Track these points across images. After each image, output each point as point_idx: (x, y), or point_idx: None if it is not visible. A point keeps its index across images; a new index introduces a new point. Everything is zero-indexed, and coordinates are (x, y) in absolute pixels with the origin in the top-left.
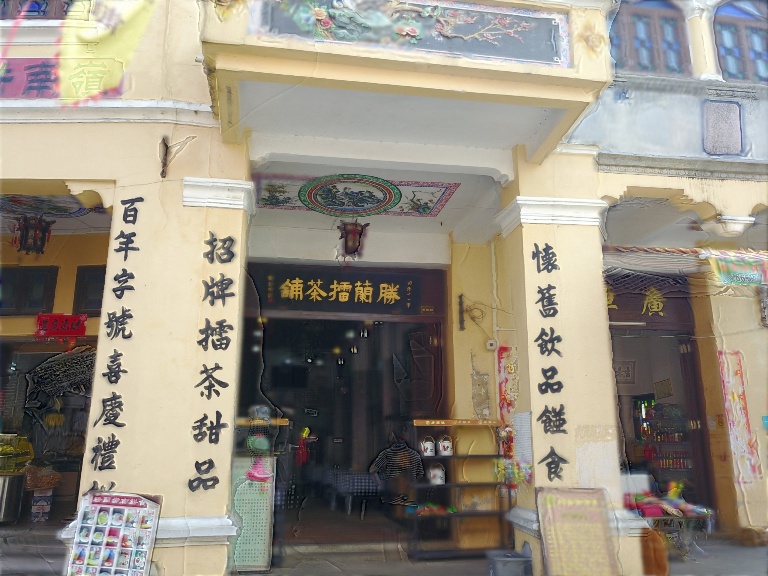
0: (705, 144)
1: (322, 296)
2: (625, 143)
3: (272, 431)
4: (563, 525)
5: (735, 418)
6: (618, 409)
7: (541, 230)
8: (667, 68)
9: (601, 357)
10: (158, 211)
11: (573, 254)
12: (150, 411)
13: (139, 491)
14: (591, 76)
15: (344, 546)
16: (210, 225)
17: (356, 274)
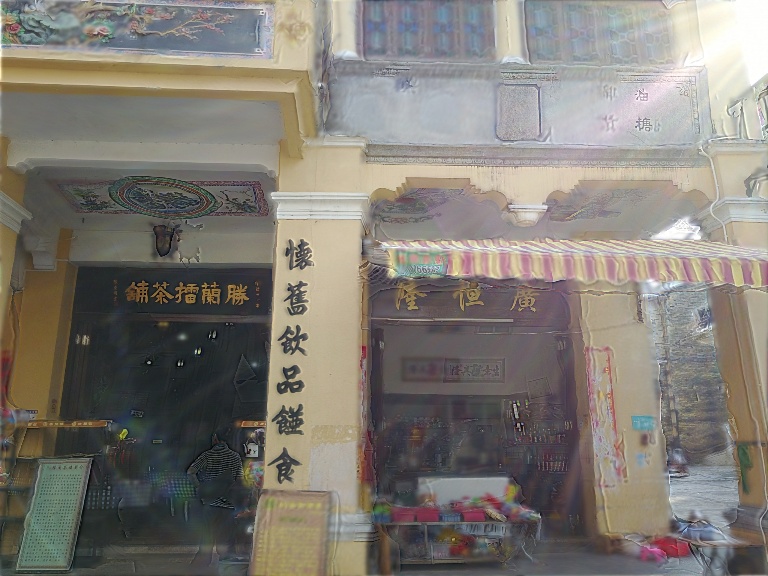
0: (498, 130)
1: (169, 298)
2: (407, 133)
3: (3, 432)
4: (279, 528)
5: (599, 418)
6: (361, 409)
7: (297, 226)
8: (467, 53)
9: (349, 355)
10: None
11: (330, 249)
12: None
13: None
14: (291, 66)
15: (166, 547)
16: None
17: (202, 276)
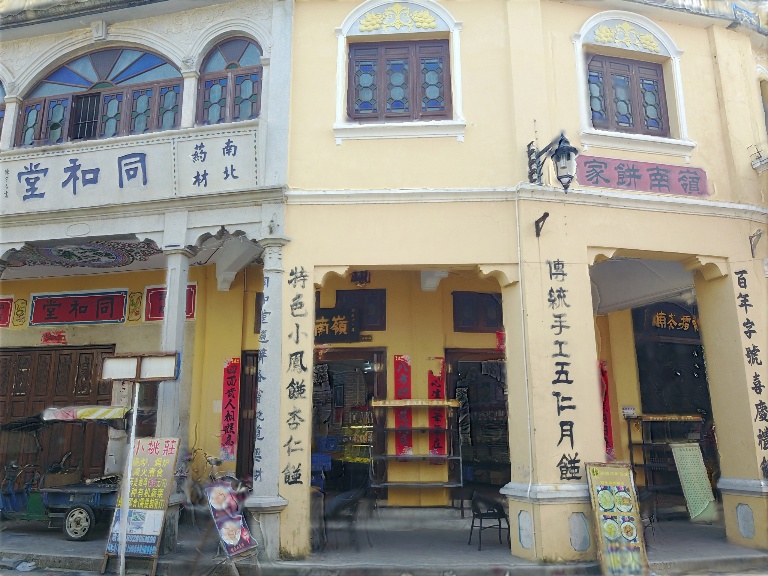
0: None
1: (674, 326)
2: None
3: None
4: None
5: None
6: None
7: None
8: None
9: None
10: (756, 280)
11: None
12: None
13: None
14: None
15: None
16: None
17: None
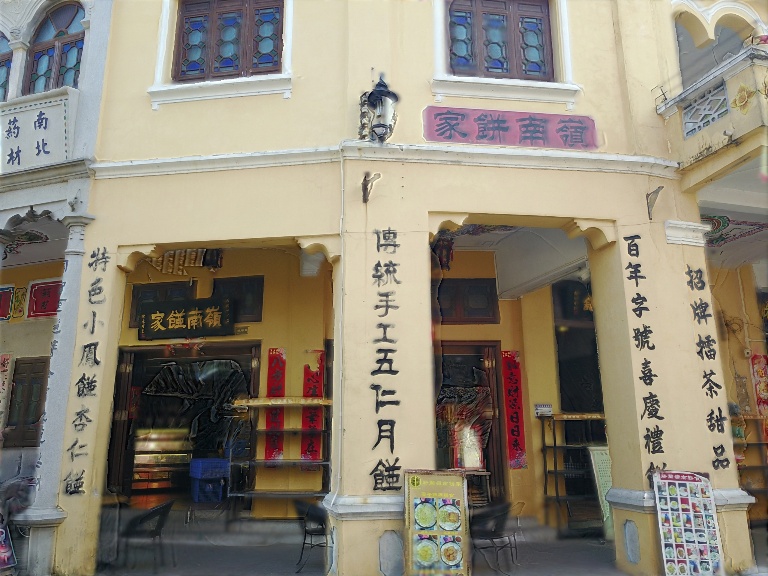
0: None
1: None
2: None
3: None
4: None
5: None
6: None
7: None
8: None
9: None
10: (652, 247)
11: None
12: (679, 407)
13: (688, 470)
14: None
15: None
16: (686, 259)
17: None
